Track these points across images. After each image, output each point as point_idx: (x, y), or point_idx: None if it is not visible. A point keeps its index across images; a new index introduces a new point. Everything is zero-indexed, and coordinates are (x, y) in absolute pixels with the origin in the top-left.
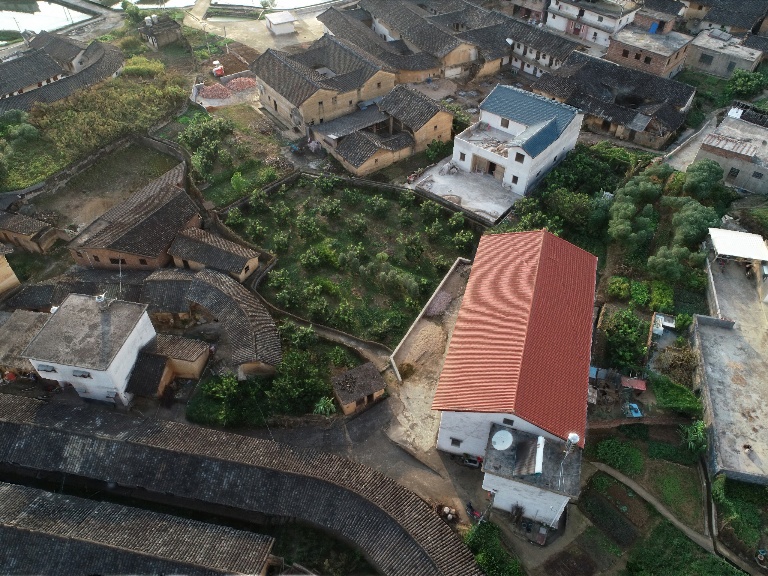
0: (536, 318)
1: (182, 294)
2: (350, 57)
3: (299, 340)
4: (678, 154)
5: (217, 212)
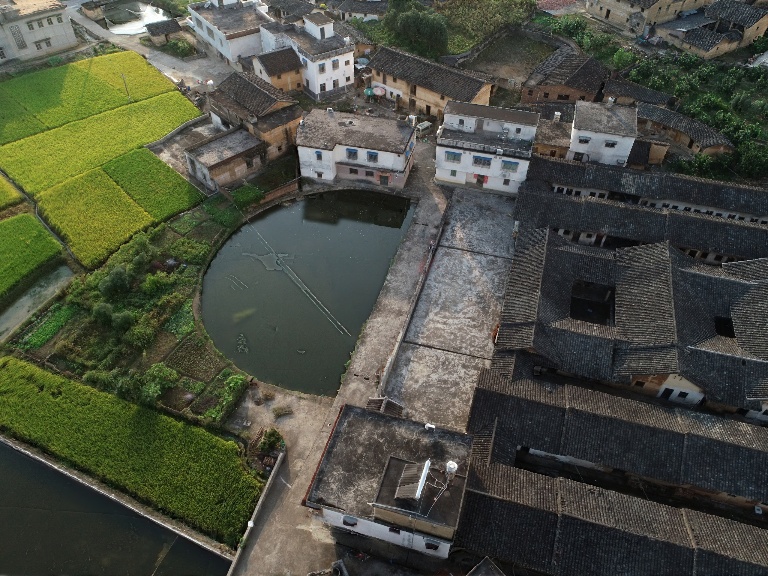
0: None
1: None
2: None
3: (742, 137)
4: None
5: (617, 73)
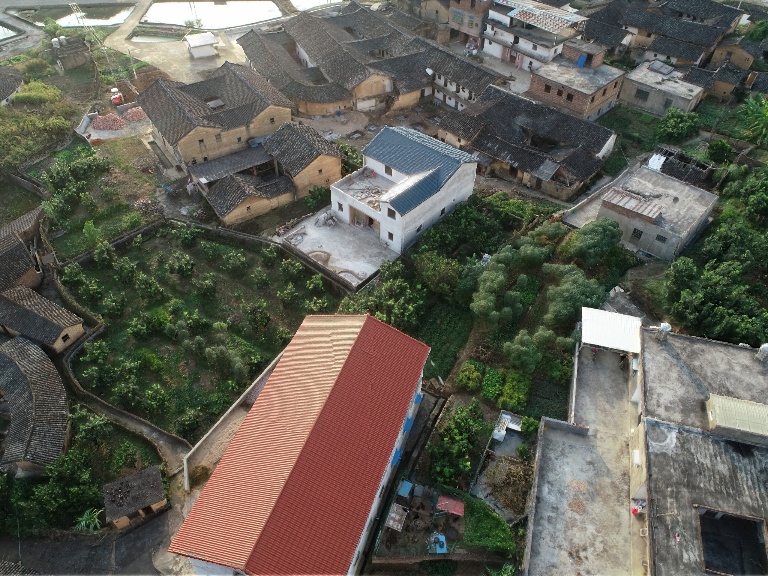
0: (319, 434)
1: None
2: (244, 89)
3: (85, 434)
4: (584, 208)
5: (56, 267)
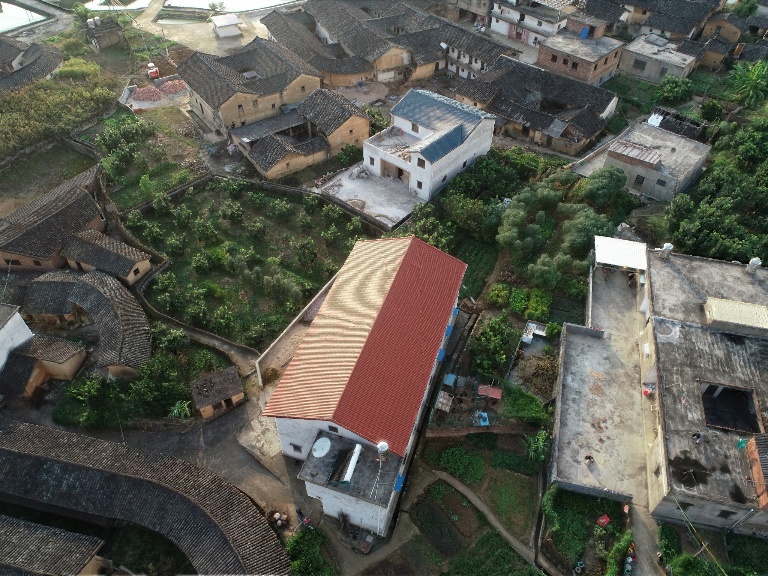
0: (381, 325)
1: (66, 296)
2: (276, 60)
3: (167, 343)
4: (591, 160)
5: (119, 214)
